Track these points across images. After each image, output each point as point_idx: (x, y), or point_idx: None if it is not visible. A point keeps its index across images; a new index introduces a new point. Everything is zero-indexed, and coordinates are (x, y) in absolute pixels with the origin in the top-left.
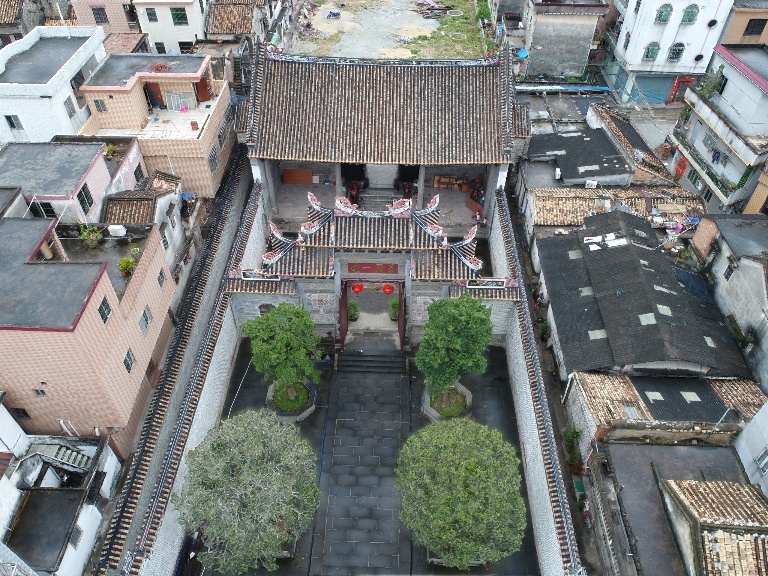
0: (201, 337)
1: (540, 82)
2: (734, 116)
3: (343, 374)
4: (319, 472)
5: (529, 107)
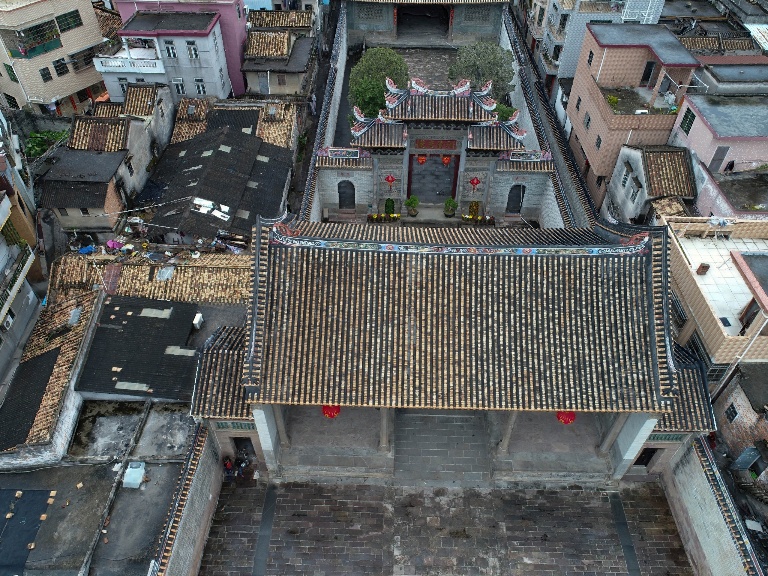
0: None
1: None
2: None
3: None
4: None
5: None
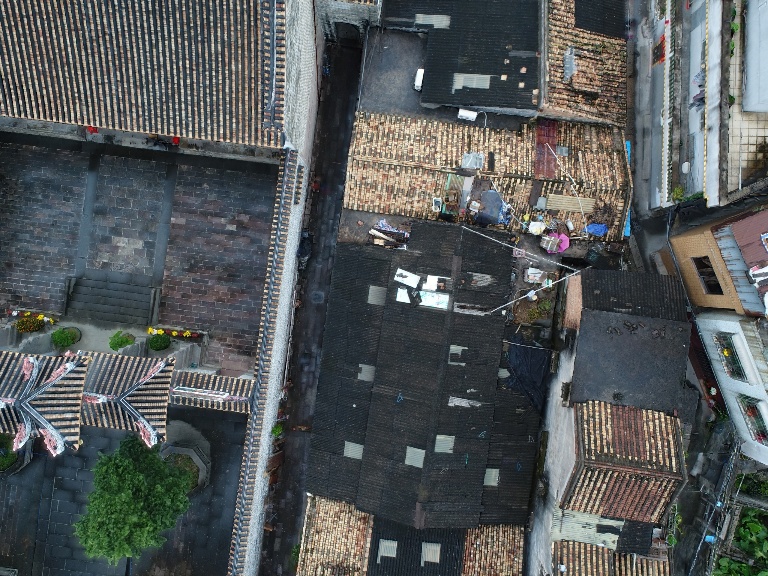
0: None
1: None
2: (753, 61)
3: None
4: (36, 537)
5: None
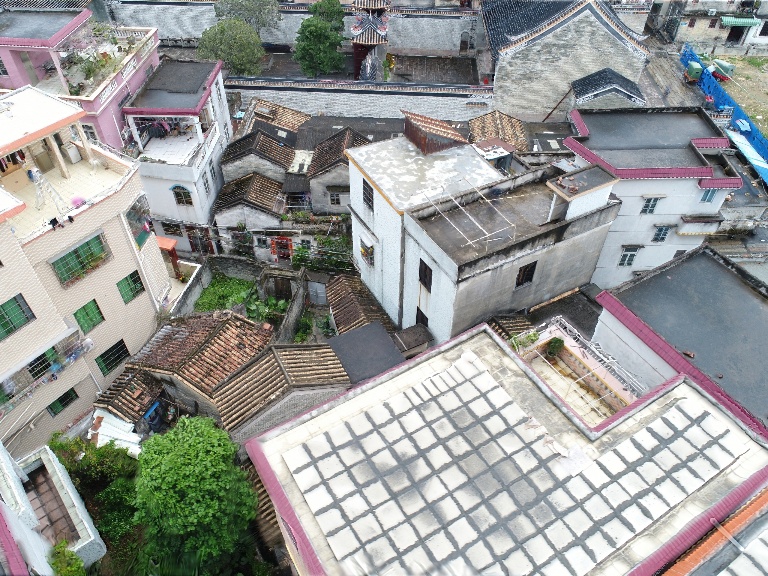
0: None
1: None
2: None
3: (345, 78)
4: None
5: (609, 84)
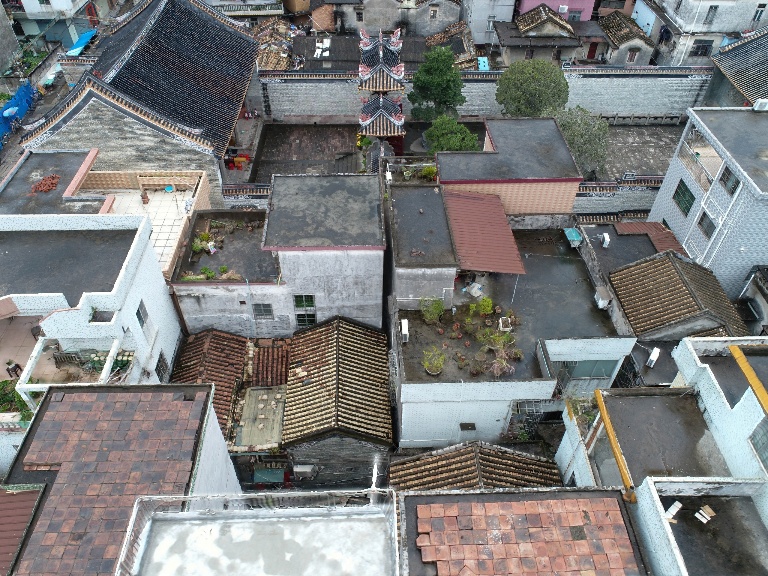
0: None
1: (38, 66)
2: None
3: None
4: None
5: None
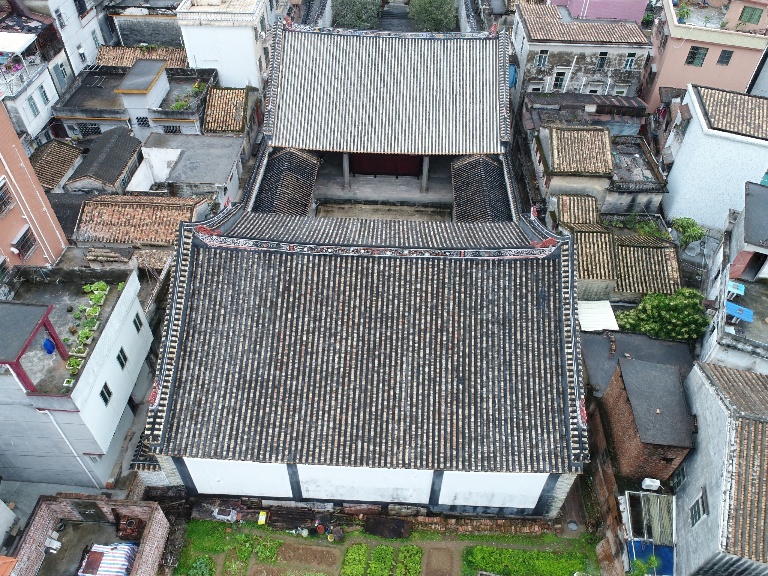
0: (318, 4)
1: None
2: None
3: (383, 19)
4: None
5: None
